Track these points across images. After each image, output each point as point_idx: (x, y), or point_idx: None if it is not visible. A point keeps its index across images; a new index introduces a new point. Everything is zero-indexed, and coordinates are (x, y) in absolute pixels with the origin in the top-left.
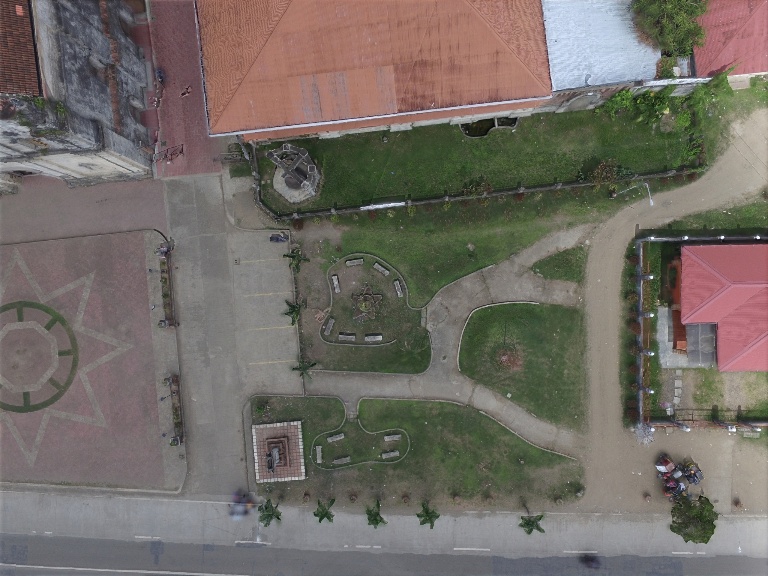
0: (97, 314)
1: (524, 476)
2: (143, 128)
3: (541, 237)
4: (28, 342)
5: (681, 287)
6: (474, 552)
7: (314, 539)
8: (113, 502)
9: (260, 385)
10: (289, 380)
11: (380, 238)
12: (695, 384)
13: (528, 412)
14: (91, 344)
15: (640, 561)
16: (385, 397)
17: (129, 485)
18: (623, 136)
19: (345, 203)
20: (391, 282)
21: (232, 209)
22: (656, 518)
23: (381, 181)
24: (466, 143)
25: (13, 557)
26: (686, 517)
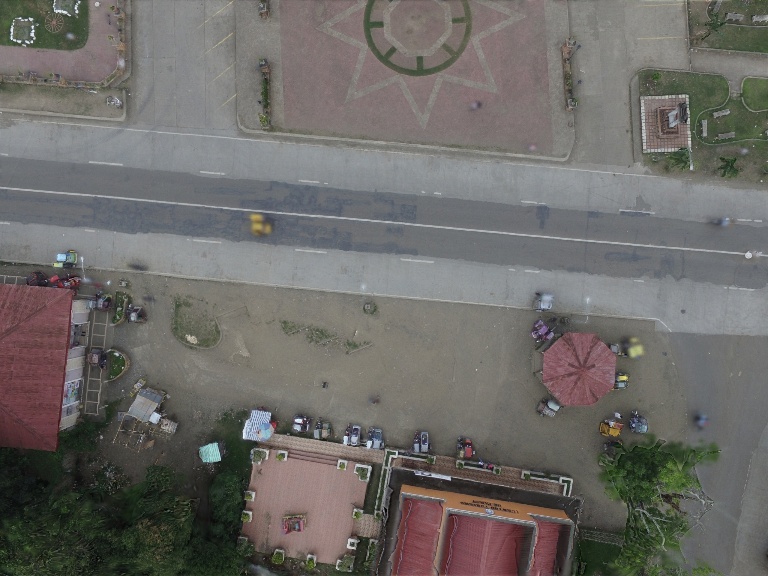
0: None
1: None
2: None
3: None
4: (423, 9)
5: None
6: None
7: (696, 211)
8: (501, 167)
9: (648, 60)
10: (676, 56)
11: None
12: None
13: None
14: (484, 13)
15: None
16: None
17: (518, 150)
18: None
19: None
20: None
21: None
22: None
23: None
24: None
25: (402, 216)
26: None
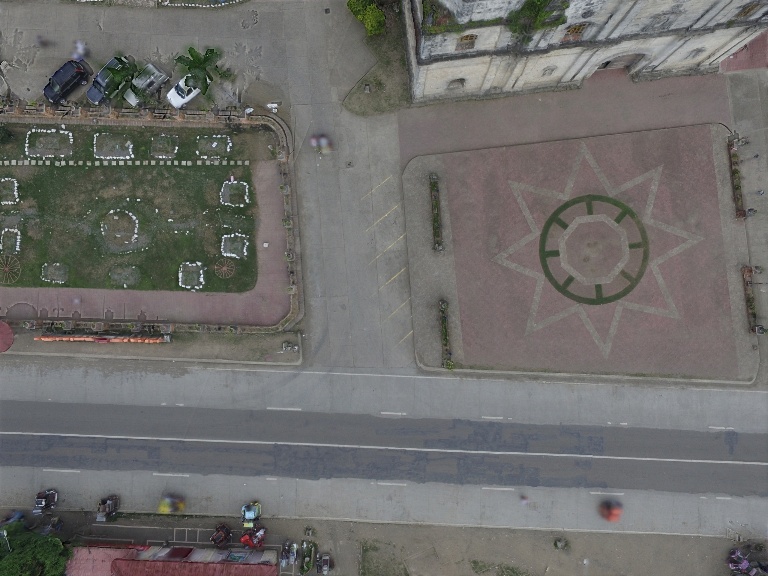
0: (666, 207)
1: None
2: None
3: None
4: (598, 235)
5: None
6: None
7: None
8: (686, 393)
9: None
10: None
11: None
12: None
13: None
14: (661, 237)
15: None
16: None
17: (703, 376)
18: None
19: None
20: None
21: None
22: None
23: None
24: None
25: (589, 448)
26: None
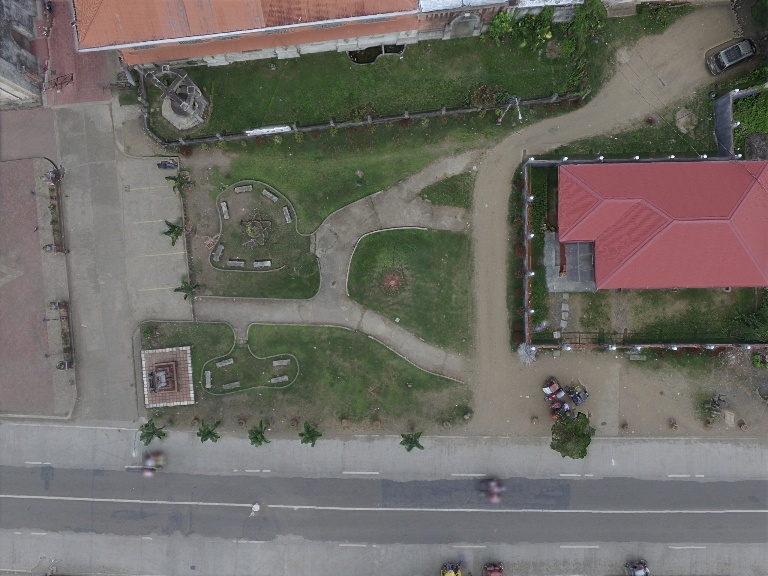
0: None
1: (412, 400)
2: (31, 56)
3: (429, 163)
4: None
5: (558, 205)
6: (363, 475)
7: (204, 464)
8: (3, 428)
9: (150, 311)
10: (179, 306)
11: (269, 165)
12: (582, 307)
13: (416, 336)
14: None
15: (528, 483)
16: (274, 322)
17: (19, 411)
18: (509, 62)
19: (234, 130)
20: (280, 209)
21: (122, 137)
22: (544, 441)
23: (269, 108)
24: (354, 70)
25: None
26: (564, 433)
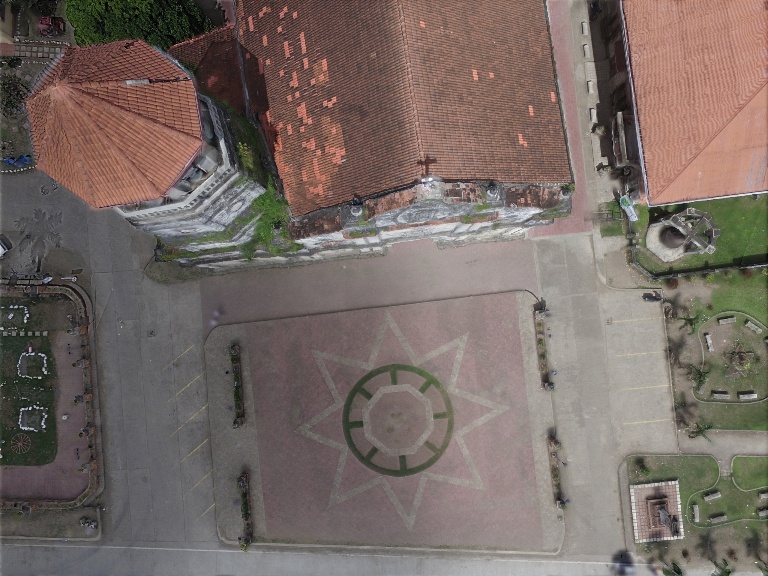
0: (471, 376)
1: None
2: None
3: None
4: (402, 405)
5: None
6: None
7: None
8: (491, 564)
9: (635, 445)
10: (664, 439)
11: (750, 296)
12: None
13: None
14: (466, 406)
15: None
16: (759, 455)
17: (508, 547)
18: None
19: (716, 261)
20: (761, 339)
21: (603, 269)
22: None
23: (752, 239)
24: None
25: None
26: None
